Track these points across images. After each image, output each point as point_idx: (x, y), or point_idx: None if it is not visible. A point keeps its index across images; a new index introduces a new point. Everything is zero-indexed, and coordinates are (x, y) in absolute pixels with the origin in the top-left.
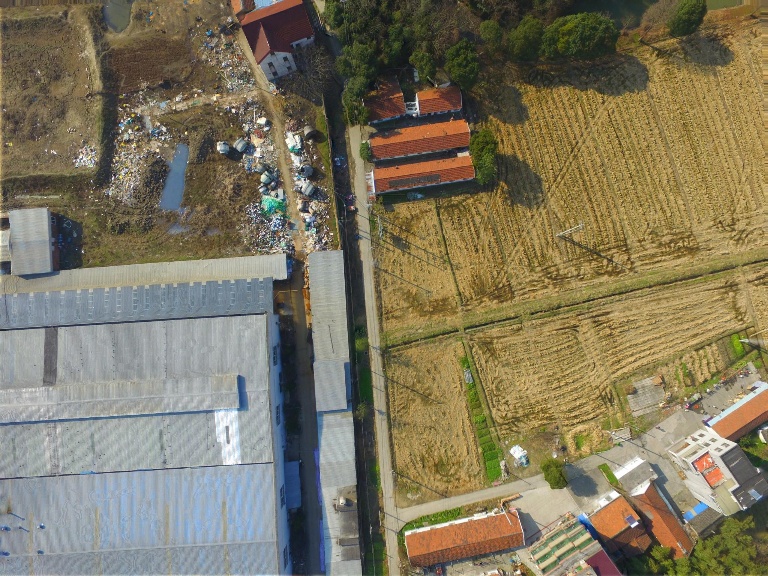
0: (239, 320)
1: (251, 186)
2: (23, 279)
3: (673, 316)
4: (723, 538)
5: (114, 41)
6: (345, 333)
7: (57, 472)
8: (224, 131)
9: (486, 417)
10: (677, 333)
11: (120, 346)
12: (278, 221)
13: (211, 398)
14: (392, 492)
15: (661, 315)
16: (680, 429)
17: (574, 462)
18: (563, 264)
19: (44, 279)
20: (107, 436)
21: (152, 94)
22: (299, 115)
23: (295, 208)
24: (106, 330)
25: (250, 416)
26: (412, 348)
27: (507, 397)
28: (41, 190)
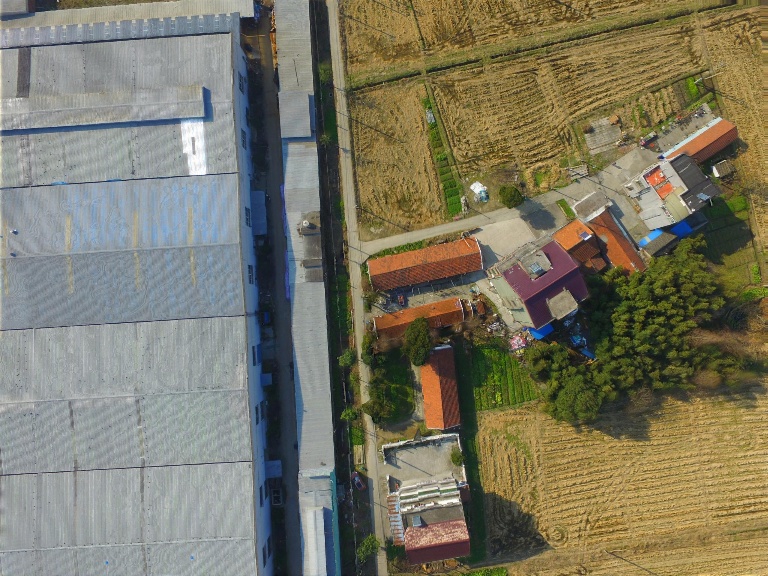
0: (205, 39)
1: None
2: None
3: (630, 59)
4: (675, 255)
5: None
6: (310, 68)
7: (30, 183)
8: None
9: (447, 155)
10: (634, 76)
11: (90, 63)
12: None
13: (177, 106)
14: (356, 226)
15: (618, 59)
16: (636, 166)
17: (532, 197)
18: (523, 10)
19: (20, 20)
20: (78, 148)
21: None
22: None
23: None
24: (77, 49)
25: (215, 127)
26: (376, 90)
27: (468, 137)
28: None
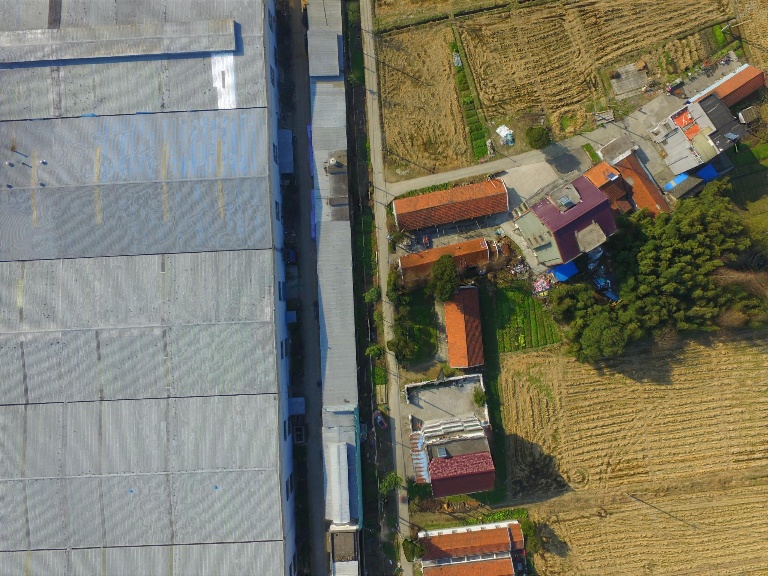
0: None
1: None
2: None
3: (657, 6)
4: (701, 198)
5: None
6: (338, 8)
7: (59, 115)
8: None
9: (474, 99)
10: (661, 23)
11: None
12: None
13: (208, 39)
14: (381, 167)
15: (645, 5)
16: (662, 112)
17: (558, 142)
18: None
19: None
20: (108, 80)
21: None
22: None
23: None
24: None
25: (245, 61)
26: (403, 33)
27: (494, 81)
28: None
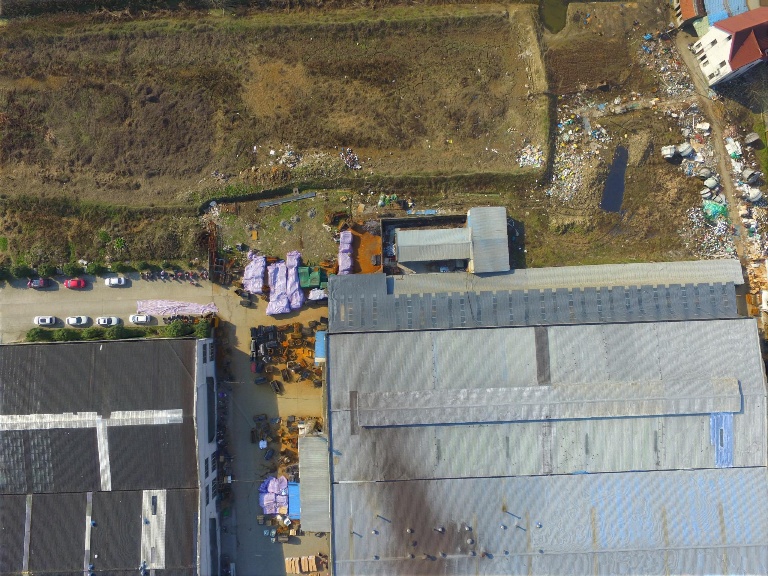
0: (728, 324)
1: (691, 190)
2: (478, 277)
3: None
4: None
5: (551, 42)
6: None
7: (549, 471)
8: (663, 135)
9: None
10: None
11: (612, 347)
12: (723, 226)
13: (713, 401)
14: None
15: None
16: None
17: None
18: None
19: (499, 277)
20: (602, 436)
21: (590, 96)
22: (737, 122)
23: (736, 214)
24: (596, 330)
25: (745, 420)
26: None
27: None
28: (482, 188)
